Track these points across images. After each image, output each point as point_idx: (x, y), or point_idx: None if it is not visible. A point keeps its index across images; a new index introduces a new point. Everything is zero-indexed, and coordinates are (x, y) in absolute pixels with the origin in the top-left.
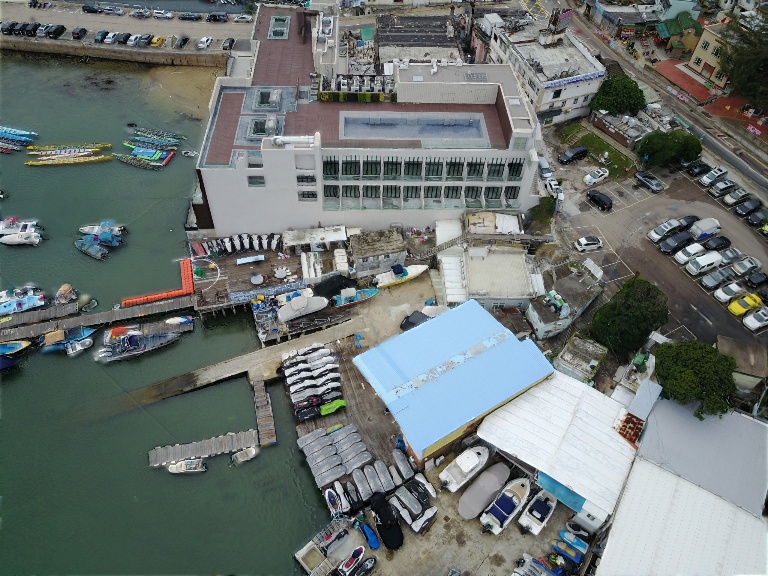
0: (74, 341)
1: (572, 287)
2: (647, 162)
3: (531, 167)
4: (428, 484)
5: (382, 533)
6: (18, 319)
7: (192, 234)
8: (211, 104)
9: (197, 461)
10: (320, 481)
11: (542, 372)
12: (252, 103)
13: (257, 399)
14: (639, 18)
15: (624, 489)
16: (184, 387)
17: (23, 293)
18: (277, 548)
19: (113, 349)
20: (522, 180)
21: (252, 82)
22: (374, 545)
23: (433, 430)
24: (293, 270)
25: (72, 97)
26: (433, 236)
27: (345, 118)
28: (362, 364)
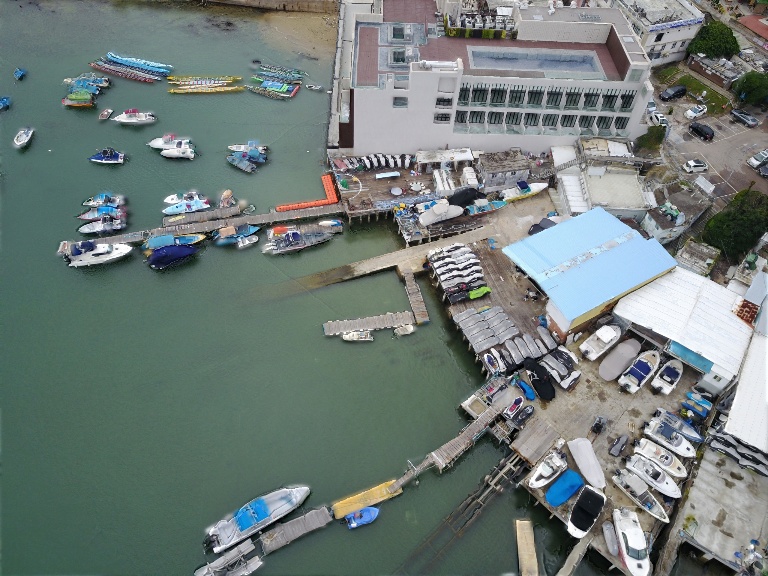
0: (243, 236)
1: (685, 200)
2: (742, 101)
3: (646, 96)
4: (571, 353)
5: (538, 387)
6: (190, 217)
7: (332, 153)
8: (354, 35)
9: (366, 332)
10: (478, 347)
11: (667, 265)
12: (387, 36)
13: (409, 287)
14: None
15: (746, 357)
16: (343, 276)
17: (189, 197)
18: (441, 402)
19: (277, 244)
20: (633, 111)
21: (383, 19)
22: (531, 396)
23: (580, 304)
24: (426, 185)
25: (198, 36)
26: (547, 161)
27: (472, 51)
28: (511, 253)
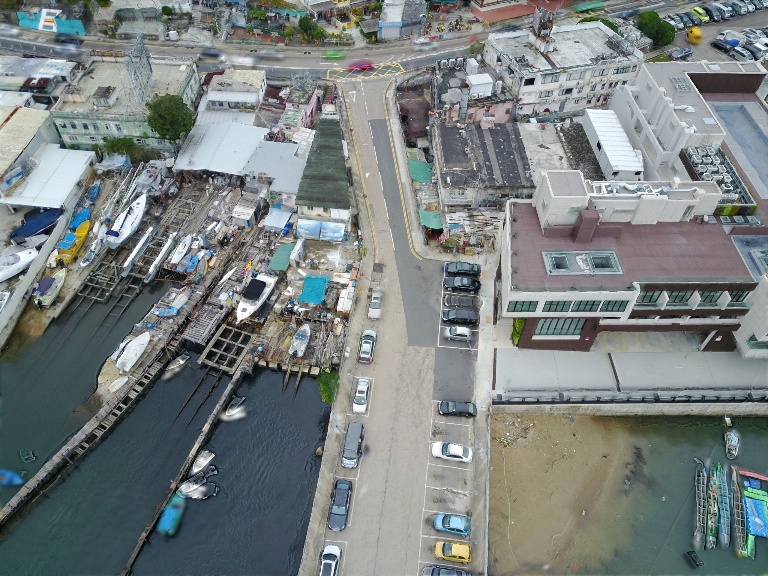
0: None
1: None
2: None
3: None
4: None
5: None
6: None
7: None
8: None
9: None
10: None
11: None
12: None
13: None
14: (418, 6)
15: None
16: None
17: None
18: None
19: None
20: None
21: None
22: None
23: None
24: None
25: None
26: None
27: None
28: None
